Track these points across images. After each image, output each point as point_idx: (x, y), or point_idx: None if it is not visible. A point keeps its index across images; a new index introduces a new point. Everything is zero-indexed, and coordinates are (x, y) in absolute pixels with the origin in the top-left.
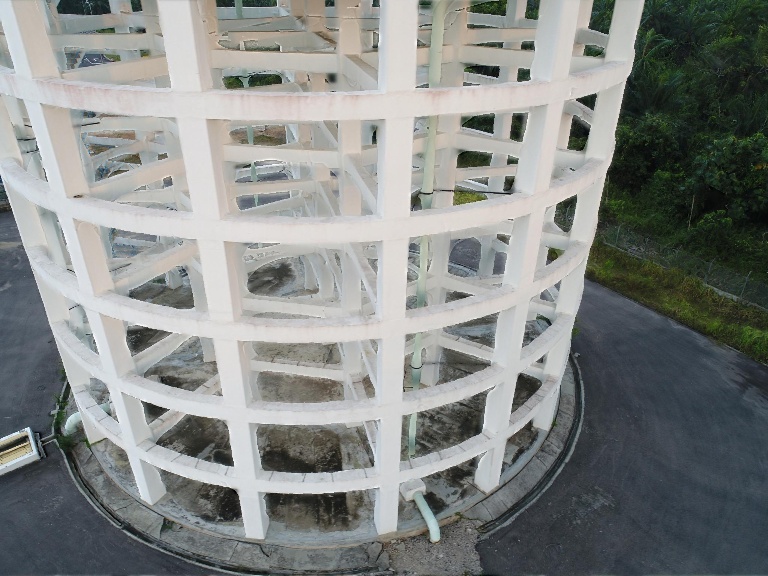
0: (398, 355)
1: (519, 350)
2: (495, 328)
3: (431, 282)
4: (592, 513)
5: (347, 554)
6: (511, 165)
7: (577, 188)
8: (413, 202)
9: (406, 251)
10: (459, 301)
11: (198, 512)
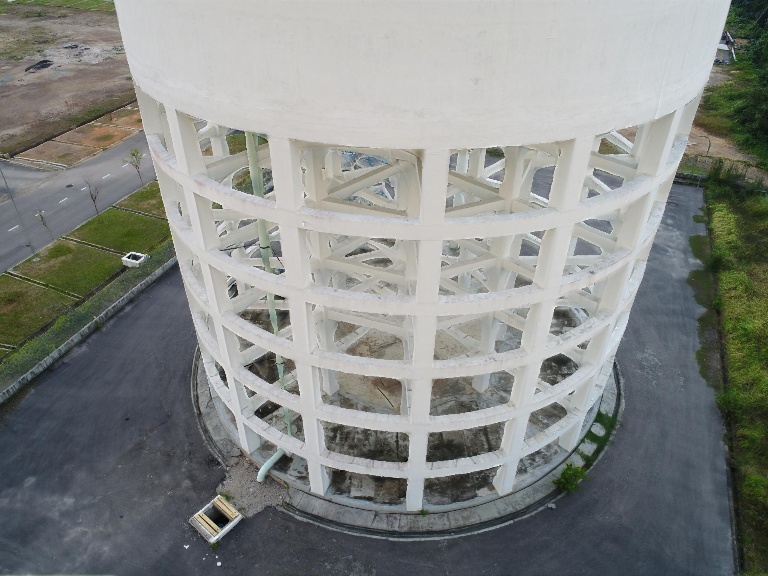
0: (222, 335)
1: (312, 399)
2: None
3: (399, 330)
4: (343, 574)
5: (227, 441)
6: None
7: (349, 305)
8: (698, 285)
9: (209, 271)
10: (256, 328)
11: None
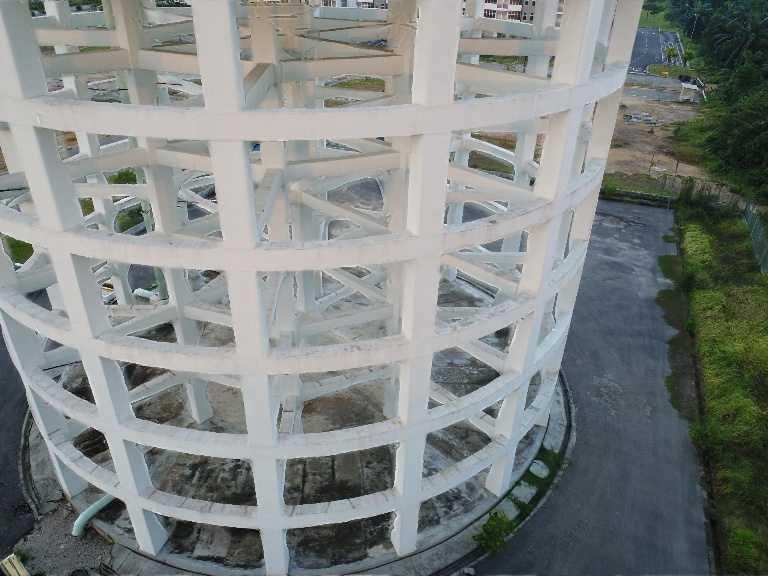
0: None
1: (111, 410)
2: (441, 463)
3: None
4: None
5: (49, 481)
6: (474, 261)
7: (126, 255)
8: (668, 305)
9: None
10: (34, 306)
11: (68, 383)
